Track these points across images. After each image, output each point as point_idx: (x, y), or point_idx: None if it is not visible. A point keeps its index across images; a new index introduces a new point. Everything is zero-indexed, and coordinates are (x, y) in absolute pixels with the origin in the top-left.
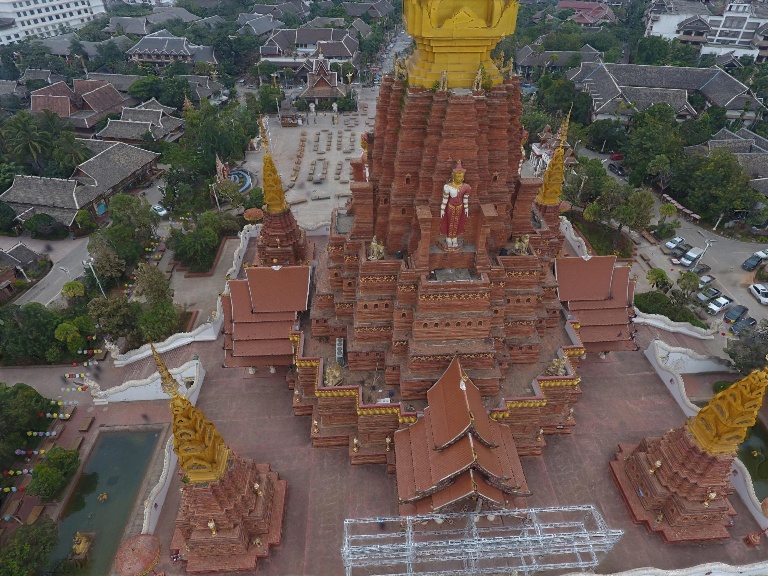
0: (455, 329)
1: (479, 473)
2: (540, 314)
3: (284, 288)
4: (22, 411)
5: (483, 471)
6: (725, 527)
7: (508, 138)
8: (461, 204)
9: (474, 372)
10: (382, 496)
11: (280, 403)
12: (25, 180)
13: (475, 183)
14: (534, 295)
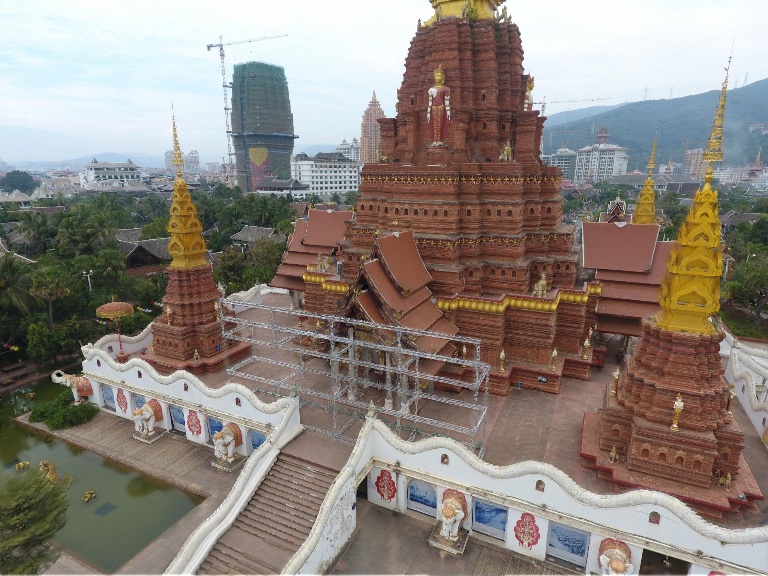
0: (423, 219)
1: (374, 297)
2: (544, 259)
3: (331, 228)
4: (142, 290)
5: (374, 288)
6: (731, 503)
7: (493, 58)
8: (442, 105)
9: (435, 265)
10: (318, 376)
11: (295, 323)
12: (248, 228)
13: (457, 89)
14: (515, 207)
